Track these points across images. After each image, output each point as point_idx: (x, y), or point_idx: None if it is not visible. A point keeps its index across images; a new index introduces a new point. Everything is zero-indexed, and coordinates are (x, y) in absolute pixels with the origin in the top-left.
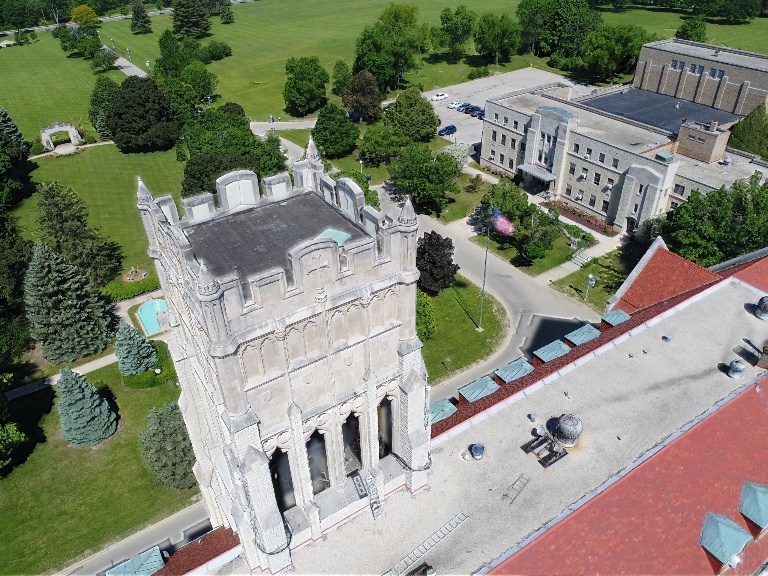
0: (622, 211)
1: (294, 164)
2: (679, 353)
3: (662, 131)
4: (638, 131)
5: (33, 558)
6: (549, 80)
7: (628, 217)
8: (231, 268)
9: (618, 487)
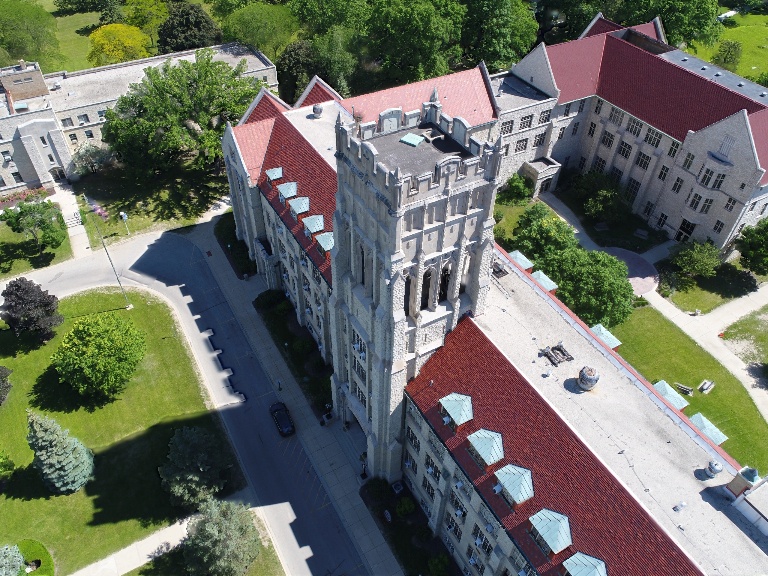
0: (41, 169)
1: (349, 130)
2: None
3: None
4: None
5: None
6: None
7: (49, 170)
8: None
9: None
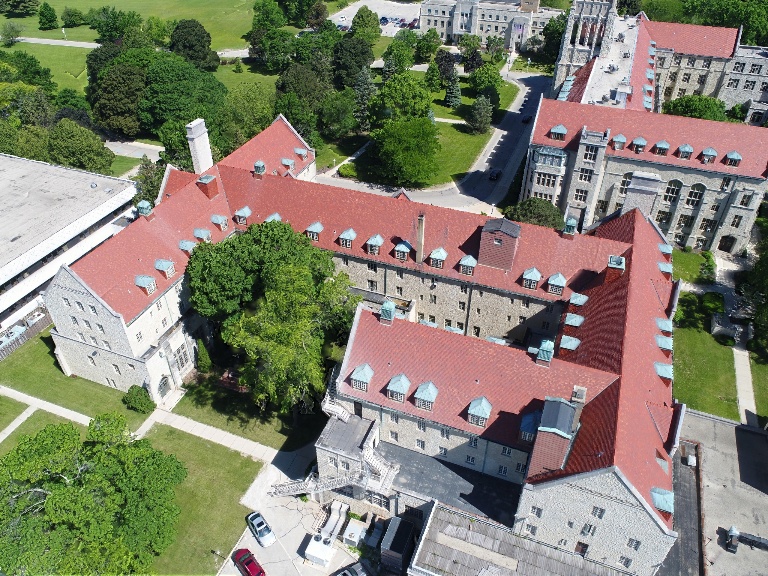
0: (513, 40)
1: None
2: None
3: (511, 4)
4: None
5: None
6: (386, 4)
7: (516, 42)
8: None
9: None
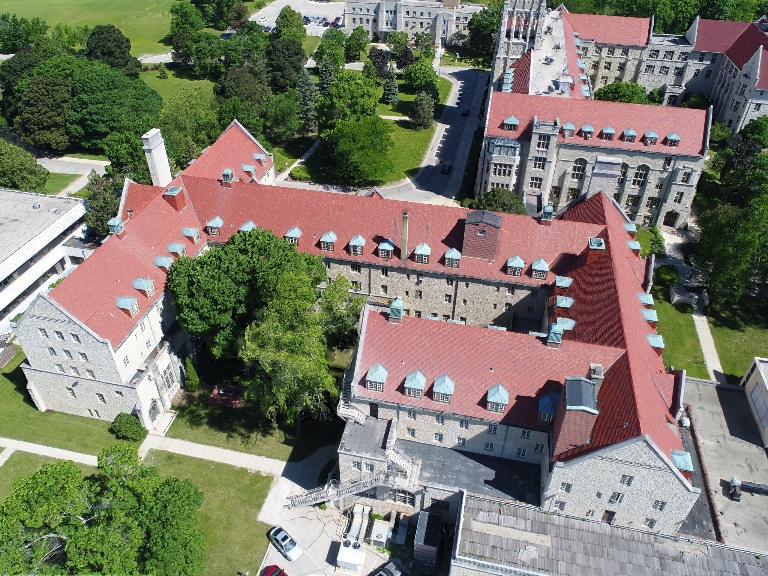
0: (438, 36)
1: None
2: None
3: None
4: (423, 2)
5: (418, 149)
6: (304, 3)
7: None
8: None
9: (565, 33)
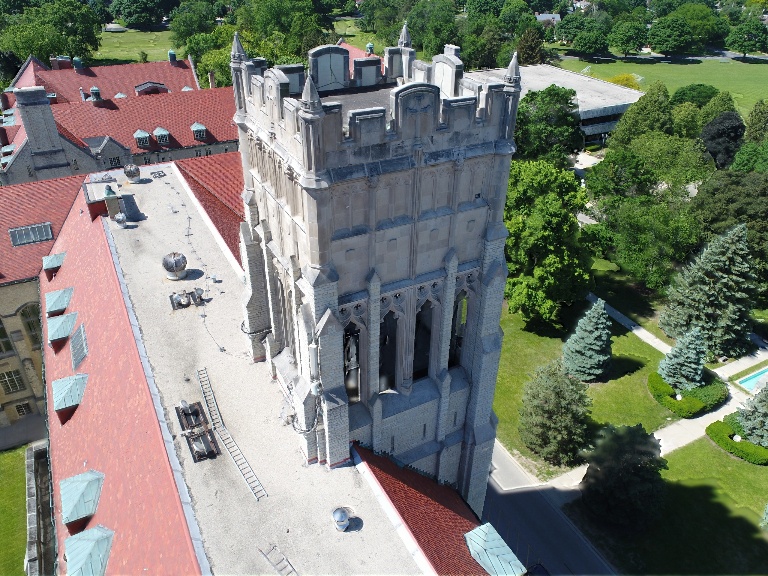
0: None
1: None
2: None
3: None
4: None
5: None
6: None
7: None
8: None
9: None
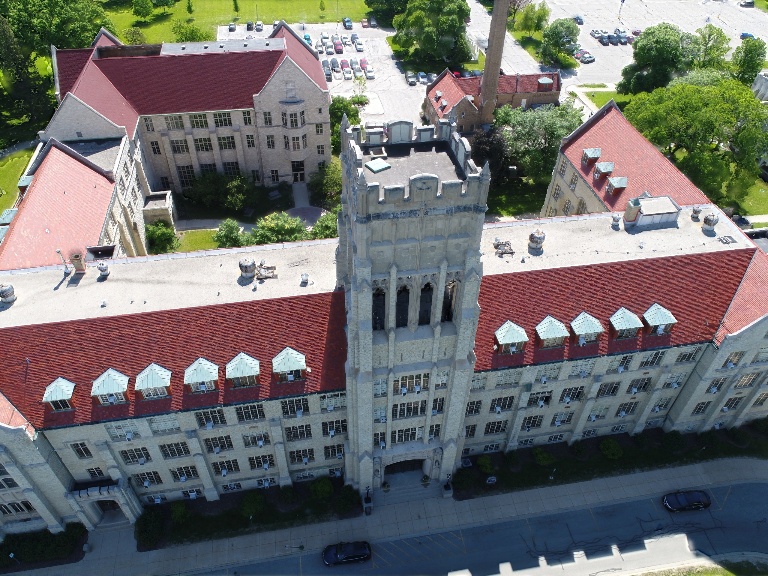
0: None
1: None
2: (112, 295)
3: None
4: None
5: None
6: None
7: None
8: (439, 165)
9: None
